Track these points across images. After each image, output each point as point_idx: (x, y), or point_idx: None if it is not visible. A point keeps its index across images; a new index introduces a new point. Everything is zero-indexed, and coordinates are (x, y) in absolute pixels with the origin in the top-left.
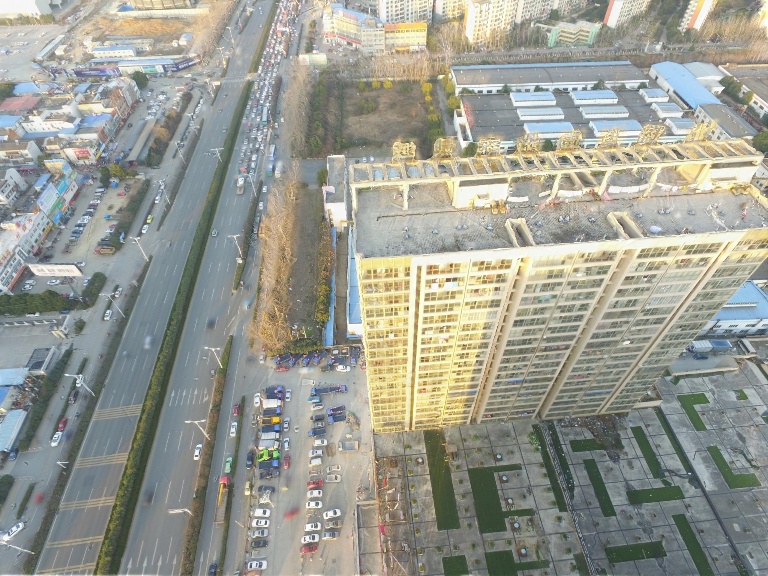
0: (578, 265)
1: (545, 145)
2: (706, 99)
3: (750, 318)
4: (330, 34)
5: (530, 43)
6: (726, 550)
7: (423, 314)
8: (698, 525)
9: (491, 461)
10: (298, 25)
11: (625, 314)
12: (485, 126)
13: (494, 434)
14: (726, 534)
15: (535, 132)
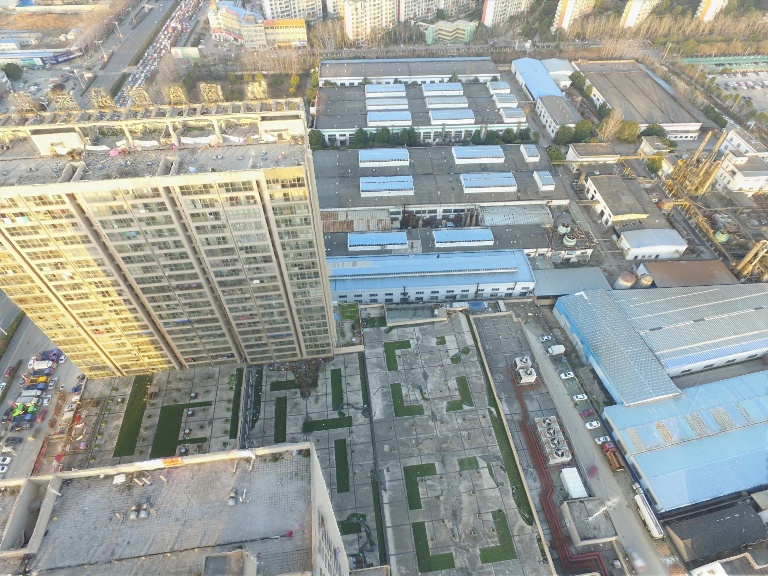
0: (130, 201)
1: (380, 132)
2: (548, 91)
3: (508, 282)
4: (217, 30)
5: (405, 40)
6: (368, 466)
7: (22, 249)
8: (353, 447)
9: (186, 399)
10: (193, 21)
11: (226, 252)
12: (332, 115)
13: (199, 377)
14: (374, 453)
15: (374, 120)
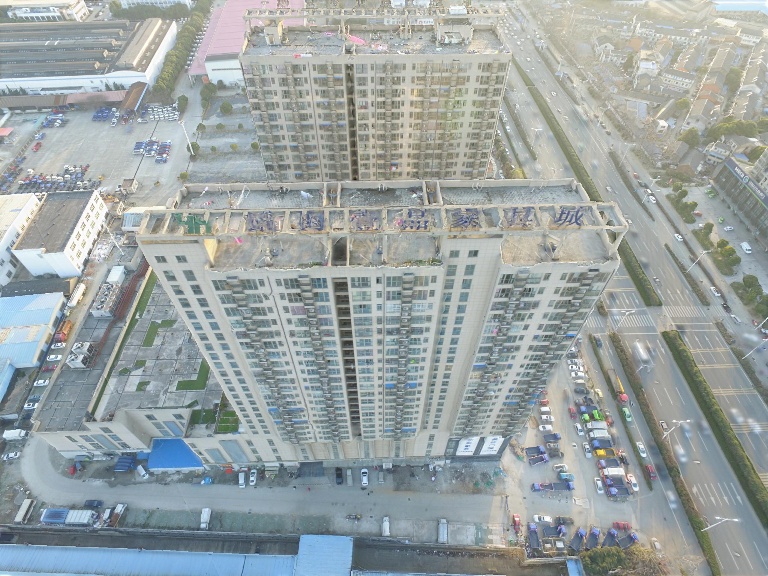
0: None
1: None
2: None
3: None
4: None
5: None
6: None
7: None
8: None
9: None
10: None
11: None
12: None
13: None
14: None
15: None
